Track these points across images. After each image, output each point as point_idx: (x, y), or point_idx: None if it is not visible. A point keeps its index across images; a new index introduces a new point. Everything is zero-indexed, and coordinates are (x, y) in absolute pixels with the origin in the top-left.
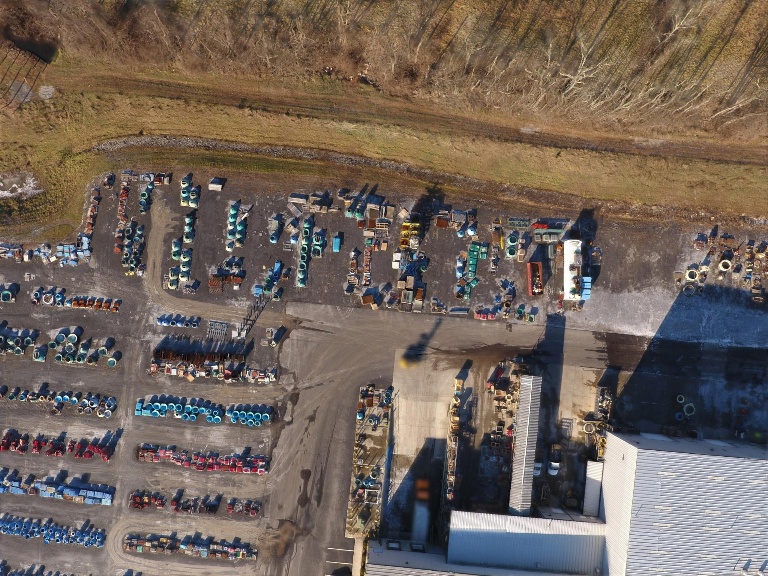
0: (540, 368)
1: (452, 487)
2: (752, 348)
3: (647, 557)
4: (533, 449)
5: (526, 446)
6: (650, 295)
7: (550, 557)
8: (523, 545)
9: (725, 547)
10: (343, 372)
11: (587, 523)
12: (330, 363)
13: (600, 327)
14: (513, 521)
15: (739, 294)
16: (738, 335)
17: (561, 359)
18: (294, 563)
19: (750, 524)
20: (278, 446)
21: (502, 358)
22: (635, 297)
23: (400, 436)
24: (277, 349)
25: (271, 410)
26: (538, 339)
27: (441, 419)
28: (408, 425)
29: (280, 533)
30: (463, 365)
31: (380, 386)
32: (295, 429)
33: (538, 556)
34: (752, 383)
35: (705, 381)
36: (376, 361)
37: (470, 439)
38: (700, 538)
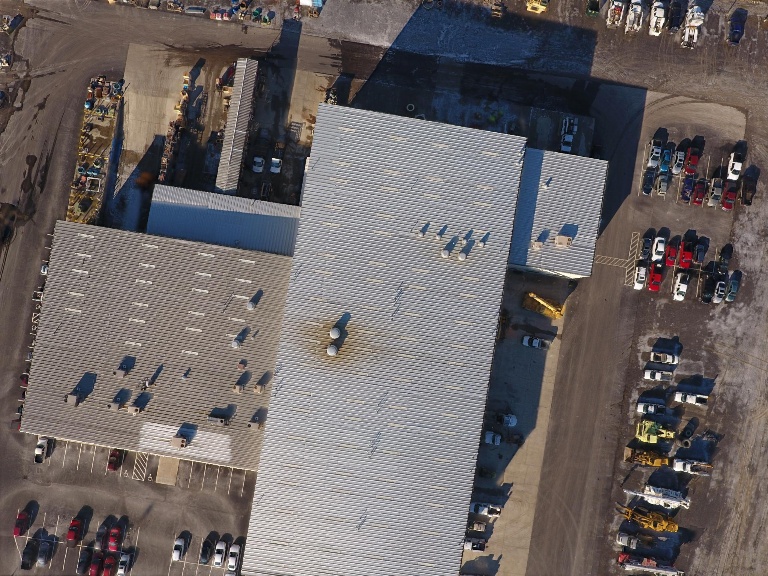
0: (273, 71)
1: (165, 169)
2: (490, 65)
3: (321, 211)
4: (243, 131)
5: (235, 126)
6: (389, 6)
7: (250, 236)
8: (224, 222)
9: (403, 208)
10: (76, 62)
11: (291, 206)
12: (63, 53)
13: (336, 35)
14: (216, 198)
15: (480, 11)
16: (476, 51)
17: (294, 63)
18: (13, 247)
19: (431, 187)
20: (6, 131)
21: (235, 59)
22: (374, 7)
23: (130, 131)
24: (12, 36)
25: (2, 95)
26: (273, 42)
27: (171, 116)
28: (138, 120)
29: (1, 216)
30: (196, 63)
31: (111, 78)
32: (24, 115)
33: (238, 234)
34: (487, 99)
35: (439, 94)
36: (109, 54)
37: (197, 136)
38: (378, 197)
